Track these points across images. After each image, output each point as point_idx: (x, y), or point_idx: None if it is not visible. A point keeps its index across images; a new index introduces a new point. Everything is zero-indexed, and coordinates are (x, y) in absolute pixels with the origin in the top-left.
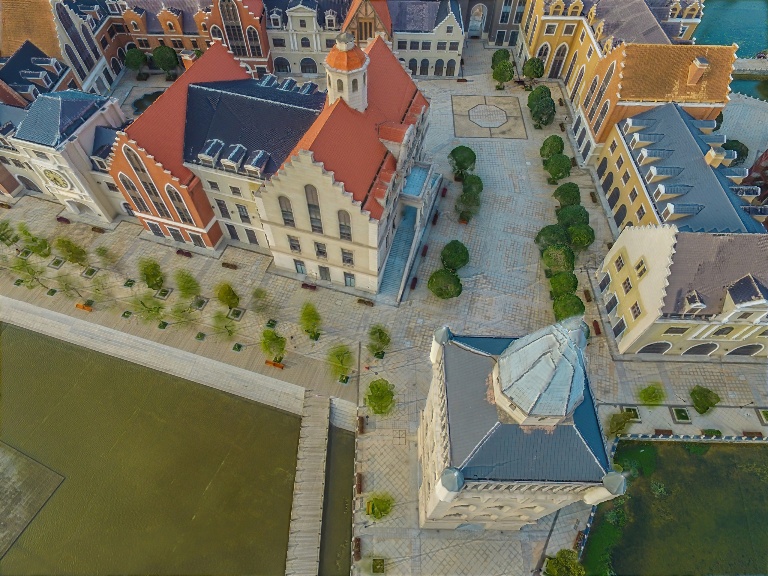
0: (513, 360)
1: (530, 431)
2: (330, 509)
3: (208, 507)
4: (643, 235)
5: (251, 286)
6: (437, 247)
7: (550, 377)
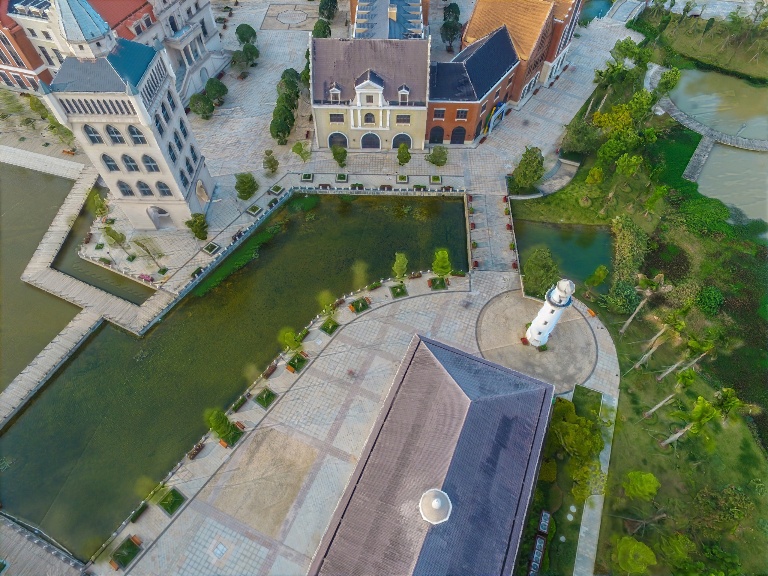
0: None
1: (83, 61)
2: (81, 224)
3: None
4: None
5: None
6: None
7: (58, 5)
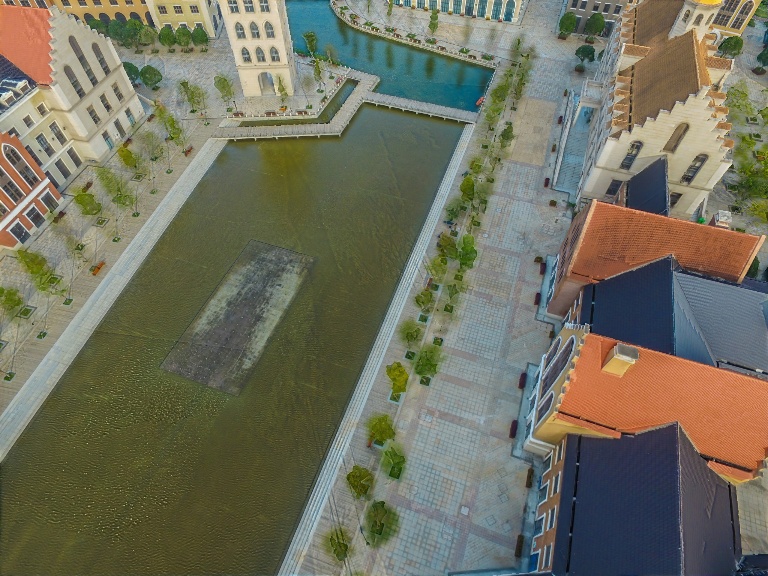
0: None
1: None
2: None
3: (277, 171)
4: None
5: (114, 173)
6: None
7: None
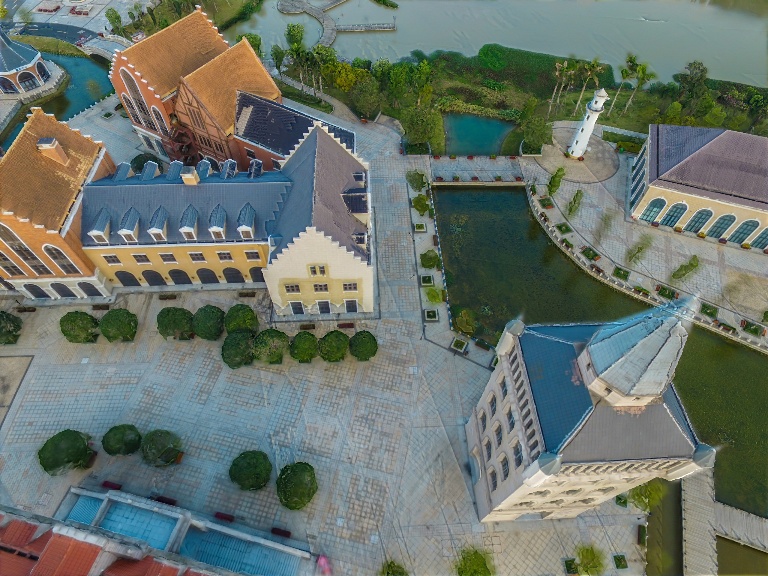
0: (649, 378)
1: None
2: None
3: None
4: (288, 258)
5: None
6: (219, 498)
7: None
